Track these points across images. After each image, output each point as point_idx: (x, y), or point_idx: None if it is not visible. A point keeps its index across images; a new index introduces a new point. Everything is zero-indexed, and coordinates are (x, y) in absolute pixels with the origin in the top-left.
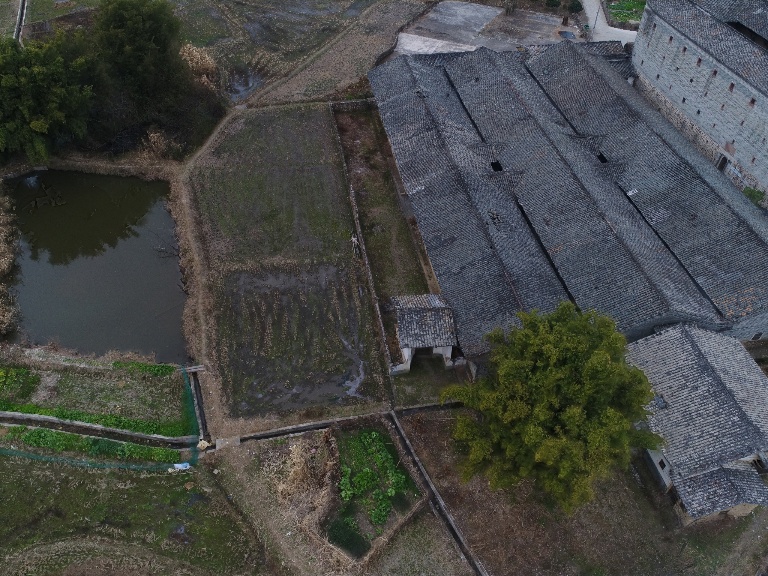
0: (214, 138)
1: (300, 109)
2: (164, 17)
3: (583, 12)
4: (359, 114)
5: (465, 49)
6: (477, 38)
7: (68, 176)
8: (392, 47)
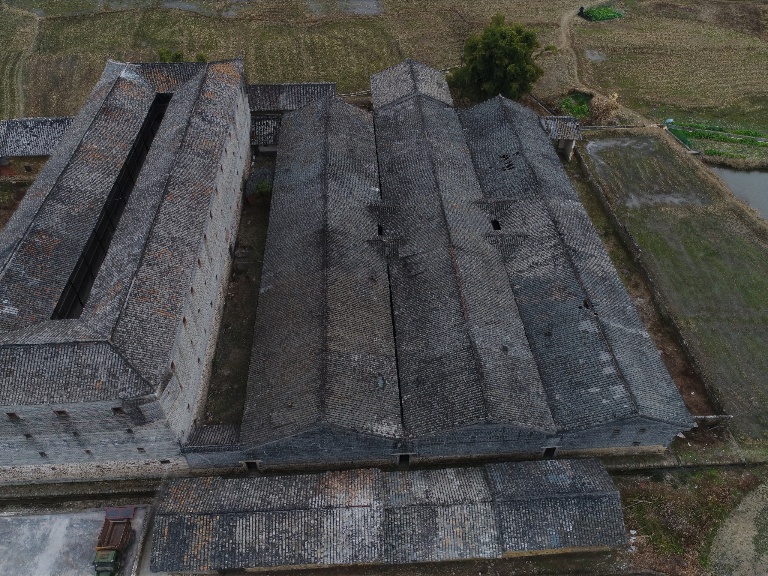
0: None
1: None
2: None
3: None
4: None
5: None
6: None
7: None
8: None
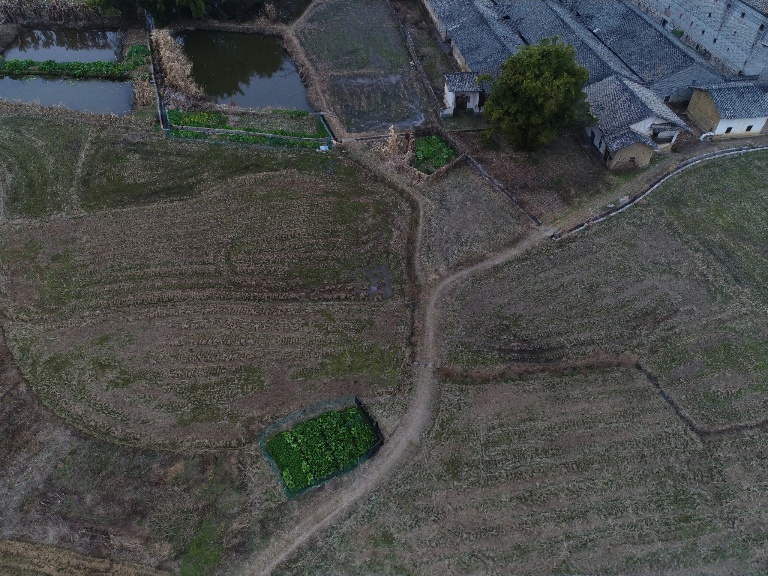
0: (307, 13)
1: None
2: None
3: None
4: (407, 2)
5: None
6: None
7: (208, 35)
8: None
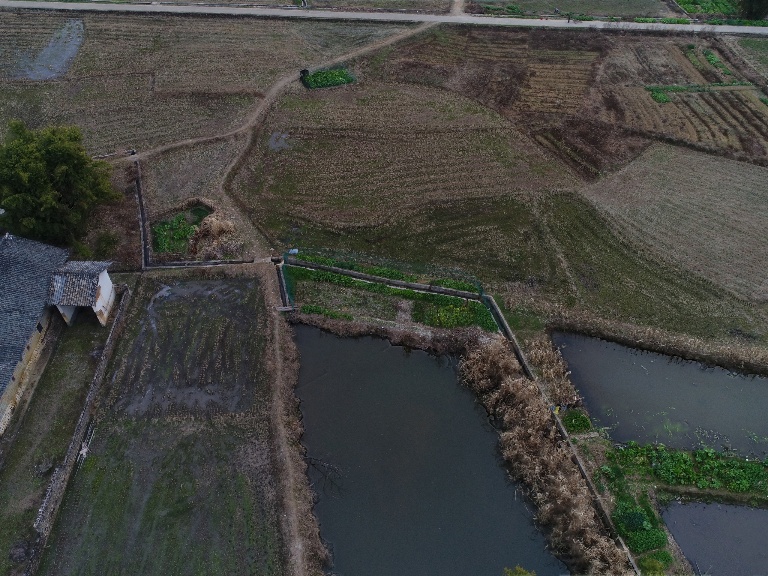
0: None
1: None
2: None
3: None
4: None
5: None
6: None
7: None
8: None
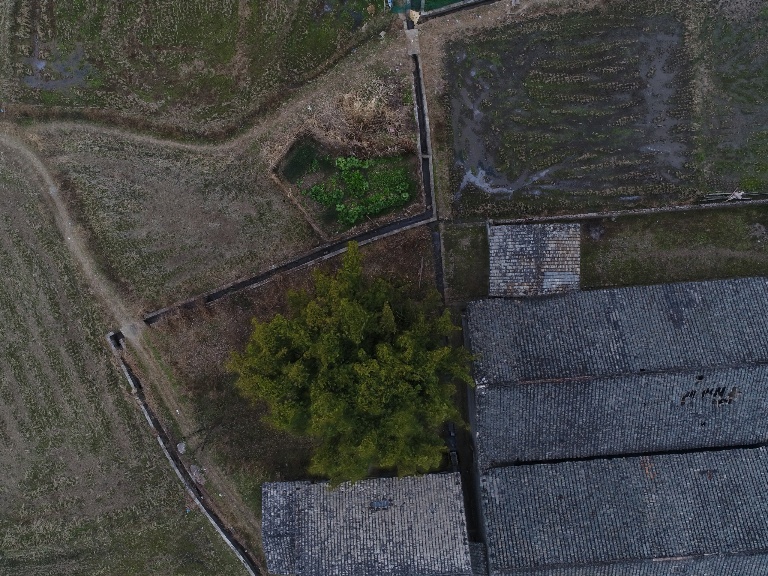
0: None
1: None
2: None
3: None
4: None
5: None
6: None
7: None
8: None
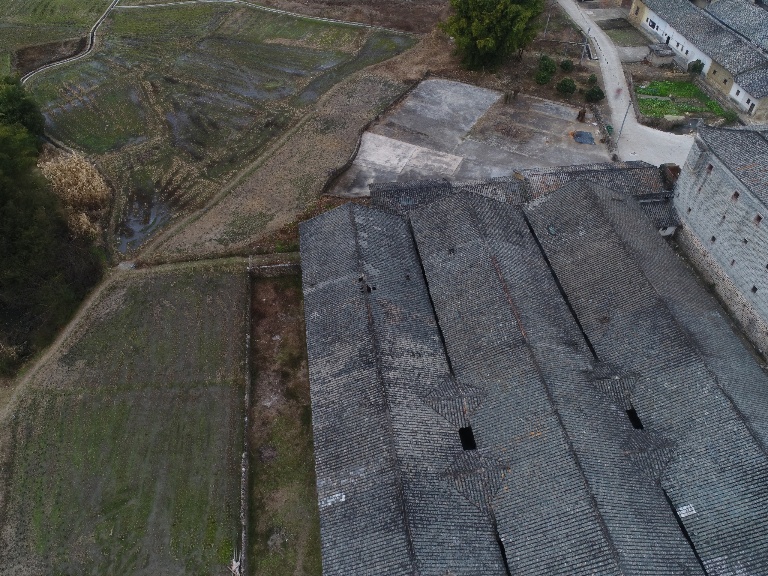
0: (73, 328)
1: (208, 270)
2: (1, 156)
3: (605, 99)
4: (287, 282)
5: (447, 162)
6: (465, 142)
7: None
8: (350, 160)
